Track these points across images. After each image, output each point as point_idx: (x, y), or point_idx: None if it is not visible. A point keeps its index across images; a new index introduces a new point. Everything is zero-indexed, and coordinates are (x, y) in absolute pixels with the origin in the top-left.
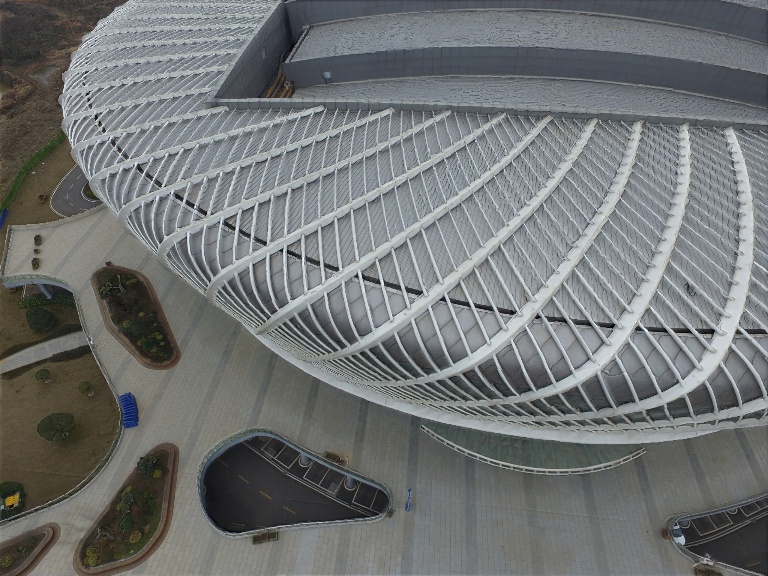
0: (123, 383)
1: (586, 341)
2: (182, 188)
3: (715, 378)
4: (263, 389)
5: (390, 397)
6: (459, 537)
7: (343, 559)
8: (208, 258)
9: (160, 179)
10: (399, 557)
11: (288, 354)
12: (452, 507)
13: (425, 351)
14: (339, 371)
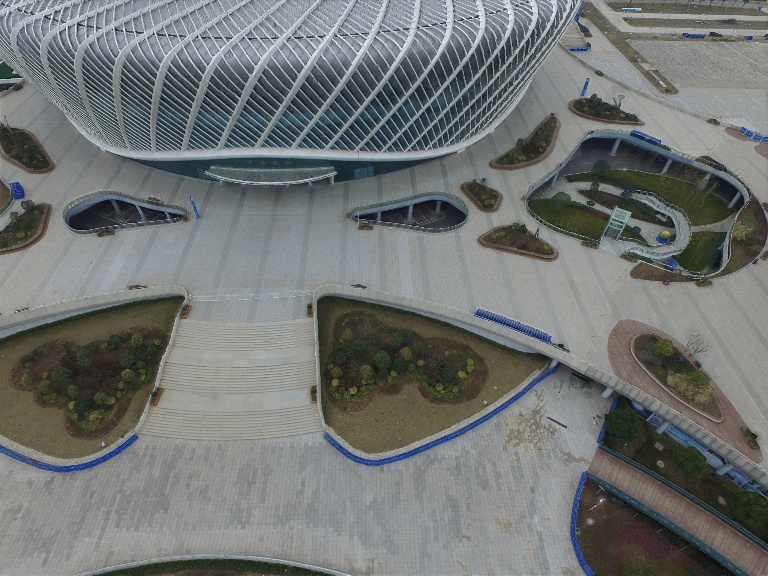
0: (13, 181)
1: (218, 44)
2: (22, 6)
3: (277, 56)
4: (112, 178)
5: (179, 150)
6: (226, 226)
7: (153, 238)
8: (37, 34)
9: (10, 5)
10: (188, 235)
11: (126, 150)
12: (225, 216)
13: (145, 58)
14: (135, 120)
